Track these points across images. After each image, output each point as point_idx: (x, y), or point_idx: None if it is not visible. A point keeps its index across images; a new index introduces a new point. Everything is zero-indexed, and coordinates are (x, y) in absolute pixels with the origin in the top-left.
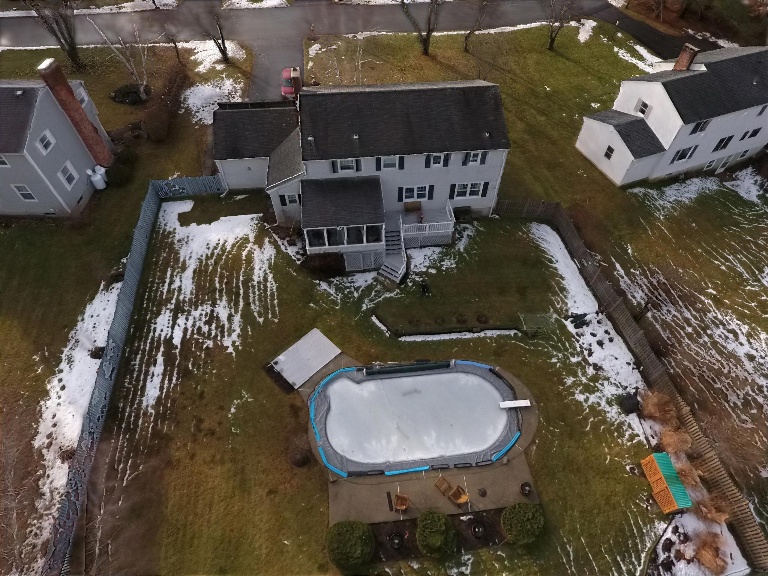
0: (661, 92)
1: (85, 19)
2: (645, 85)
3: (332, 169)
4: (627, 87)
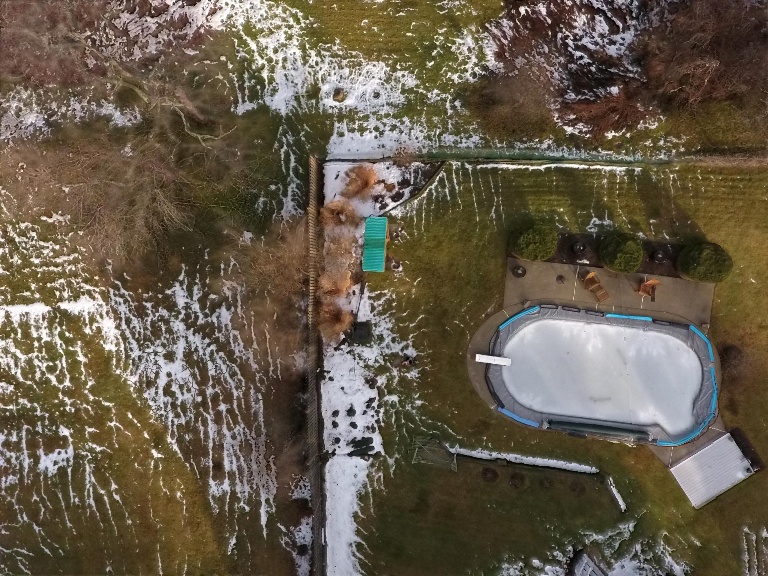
0: None
1: None
2: None
3: None
4: None
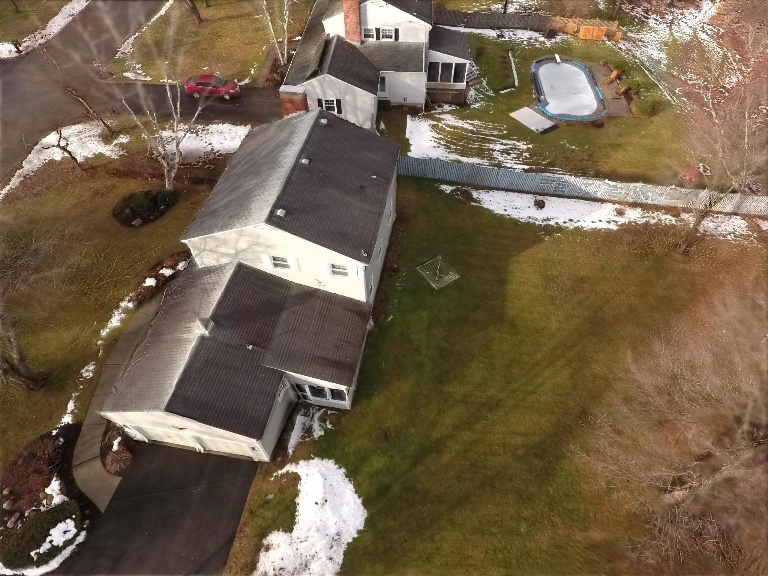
0: None
1: None
2: None
3: None
4: None
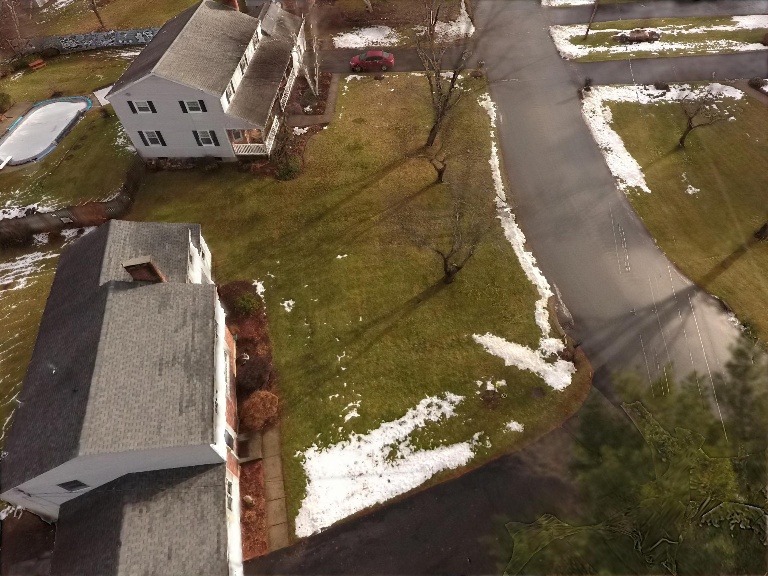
0: None
1: None
2: None
3: None
4: None
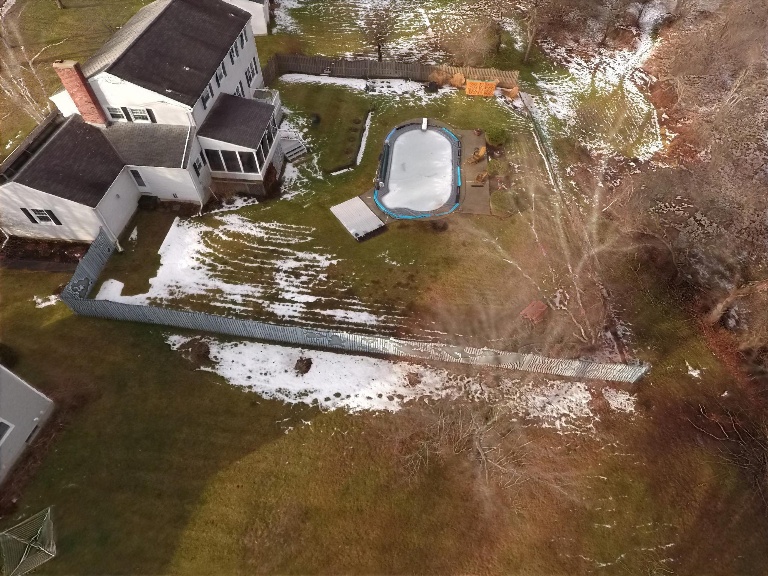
0: None
1: None
2: None
3: (203, 106)
4: None
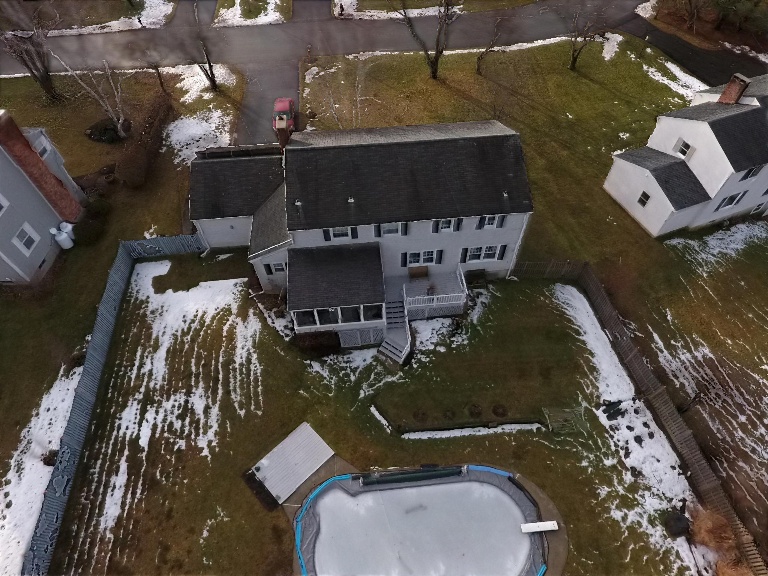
0: (707, 133)
1: (65, 41)
2: (687, 123)
3: (323, 237)
4: (665, 123)
